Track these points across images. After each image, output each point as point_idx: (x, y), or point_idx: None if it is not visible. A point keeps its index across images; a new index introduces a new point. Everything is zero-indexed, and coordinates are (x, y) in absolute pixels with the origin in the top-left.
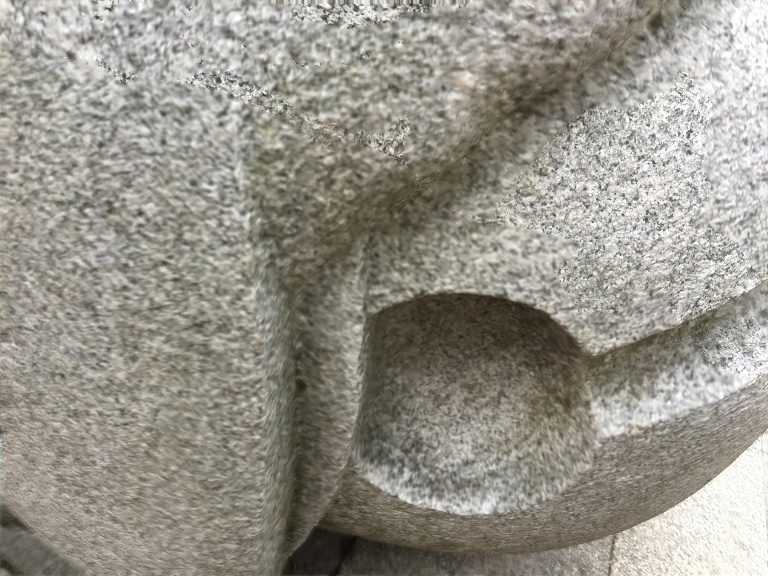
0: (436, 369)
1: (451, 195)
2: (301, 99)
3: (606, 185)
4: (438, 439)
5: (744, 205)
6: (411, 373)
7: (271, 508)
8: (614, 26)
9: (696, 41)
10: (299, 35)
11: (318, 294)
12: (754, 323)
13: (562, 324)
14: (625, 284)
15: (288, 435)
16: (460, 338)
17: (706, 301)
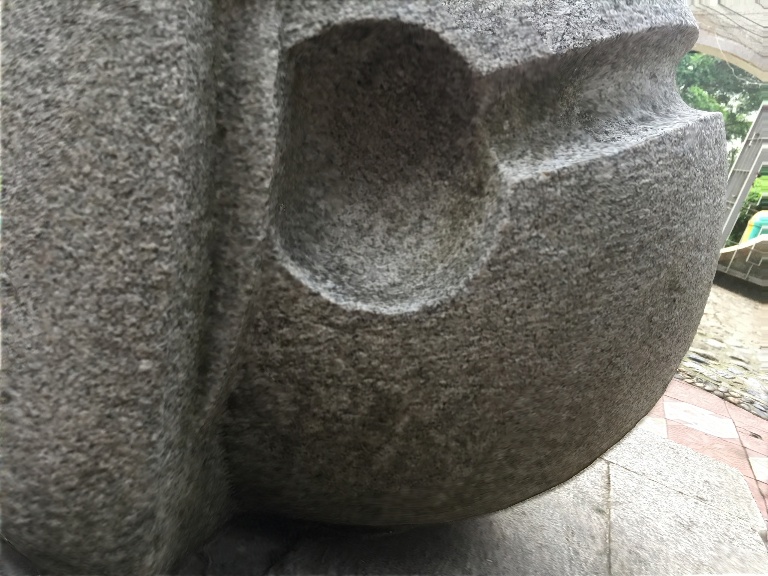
0: (358, 197)
1: None
2: None
3: None
4: (364, 268)
5: None
6: (333, 199)
7: (181, 258)
8: None
9: None
10: None
11: (240, 29)
12: (635, 123)
13: (450, 43)
14: (497, 10)
15: (205, 175)
16: (377, 160)
17: (571, 37)
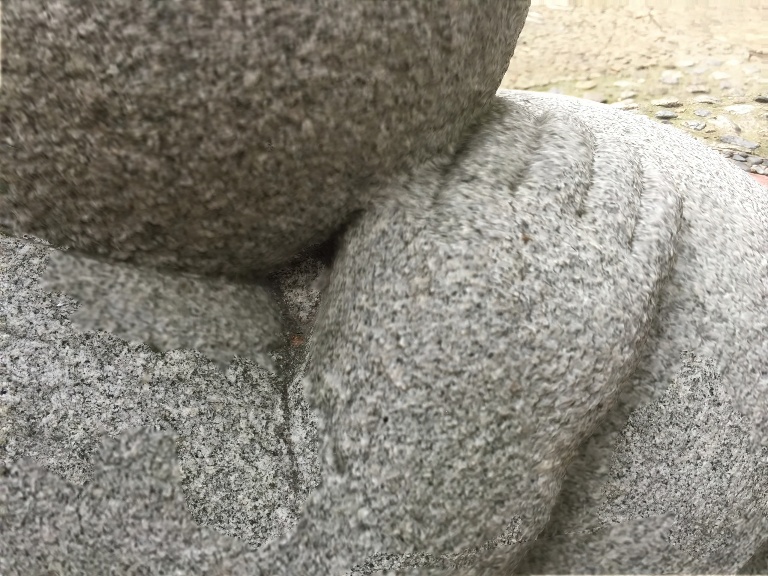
0: None
1: (558, 524)
2: (436, 547)
3: (672, 461)
4: None
5: None
6: None
7: None
8: (629, 372)
9: (680, 323)
10: (417, 505)
11: None
12: None
13: (690, 574)
14: (723, 522)
15: None
16: None
17: None
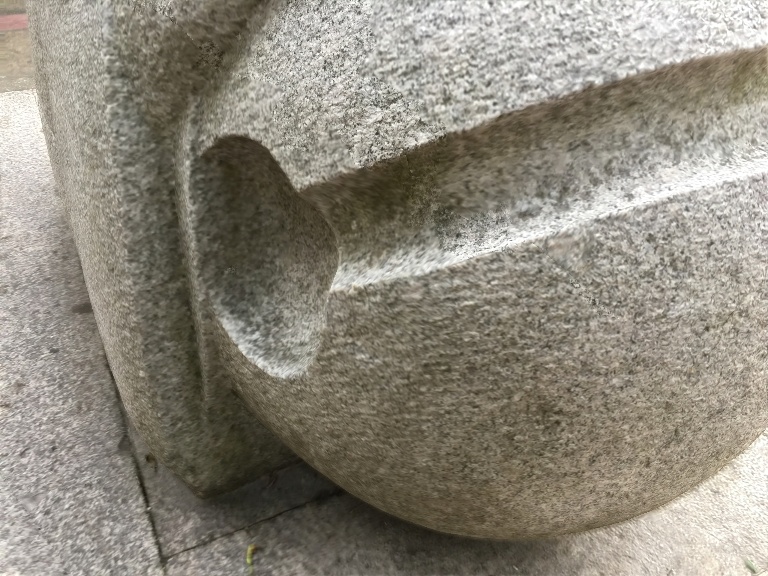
0: (301, 257)
1: None
2: None
3: (301, 42)
4: (294, 321)
5: (406, 57)
6: (285, 257)
7: (150, 311)
8: None
9: None
10: None
11: None
12: (505, 220)
13: (277, 160)
14: (312, 124)
15: (163, 253)
16: (312, 227)
17: (379, 148)
